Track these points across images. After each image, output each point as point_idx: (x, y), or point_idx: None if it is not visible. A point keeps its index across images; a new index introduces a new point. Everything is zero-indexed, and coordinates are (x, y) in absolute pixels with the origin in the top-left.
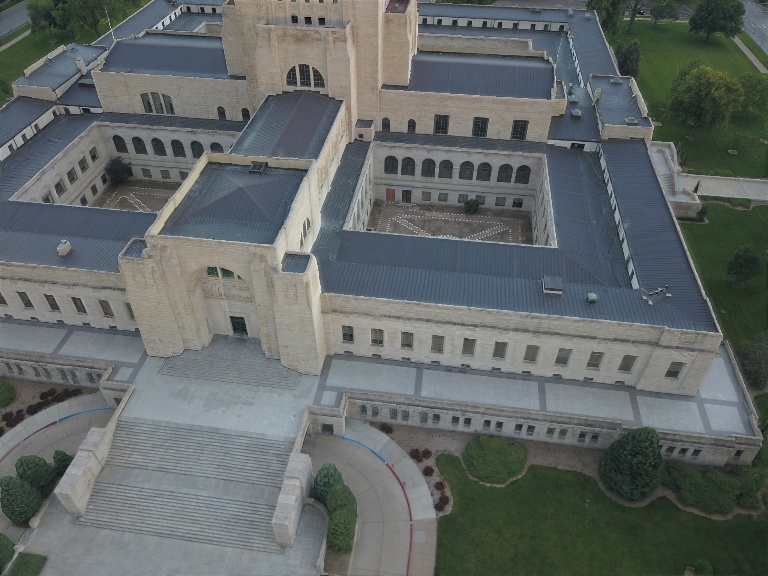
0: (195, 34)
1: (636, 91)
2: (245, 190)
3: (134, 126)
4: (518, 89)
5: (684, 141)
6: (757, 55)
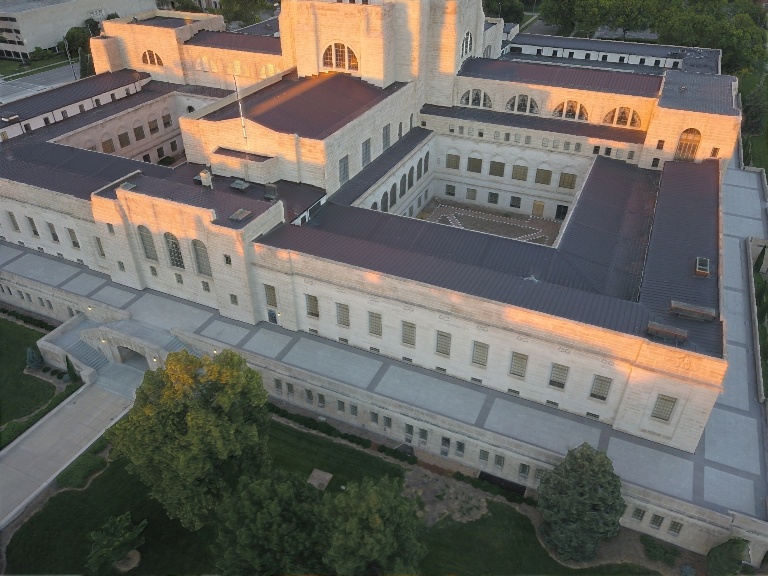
0: None
1: None
2: (166, 20)
3: None
4: (235, 113)
5: None
6: None
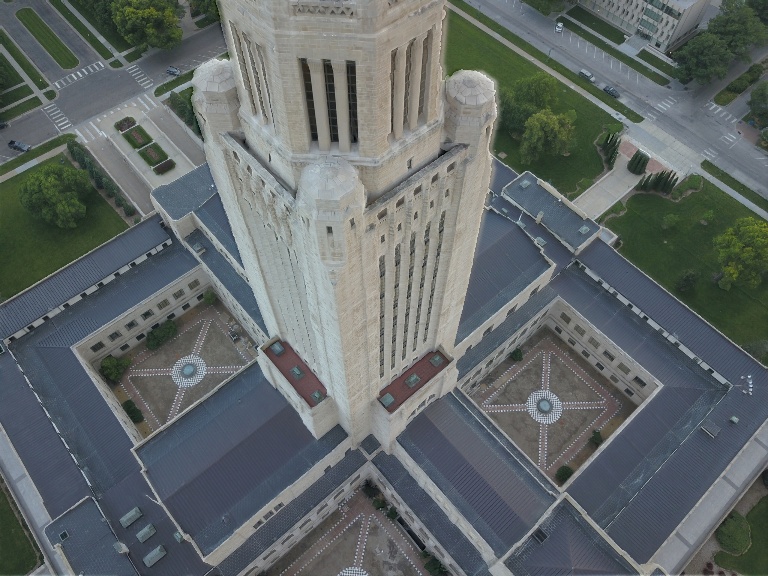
0: (189, 410)
1: (556, 194)
2: (579, 568)
3: (268, 552)
4: (518, 265)
5: (534, 164)
6: (464, 10)
